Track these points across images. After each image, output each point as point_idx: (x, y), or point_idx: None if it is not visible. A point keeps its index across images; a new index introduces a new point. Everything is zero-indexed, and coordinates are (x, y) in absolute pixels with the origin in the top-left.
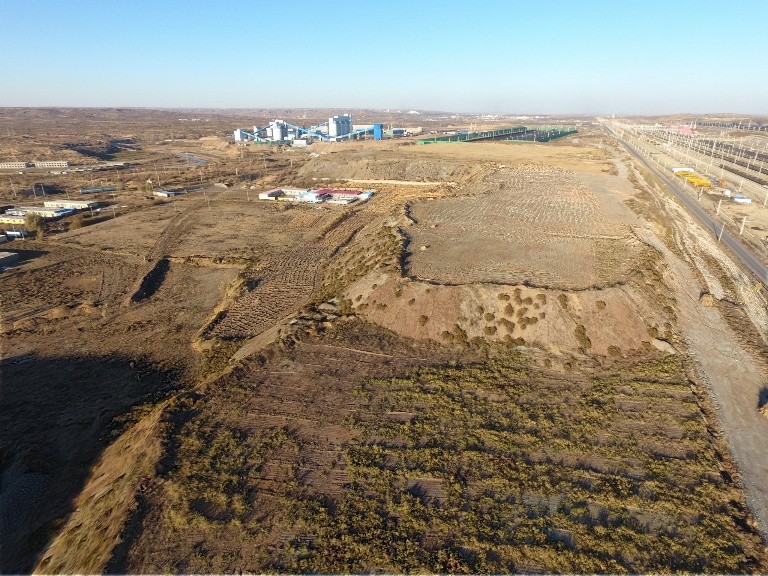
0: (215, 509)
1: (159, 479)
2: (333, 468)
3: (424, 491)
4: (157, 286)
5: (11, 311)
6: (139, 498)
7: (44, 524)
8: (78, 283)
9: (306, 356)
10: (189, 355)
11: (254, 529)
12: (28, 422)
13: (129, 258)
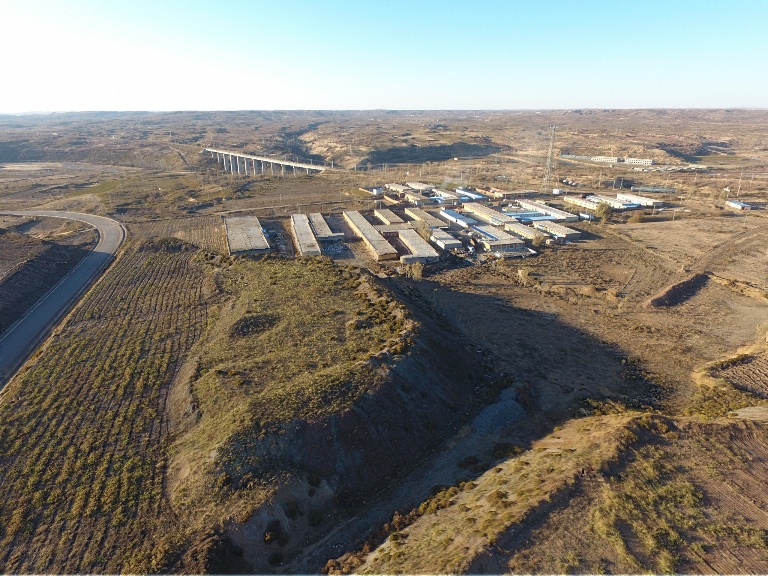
0: (638, 545)
1: (600, 476)
2: None
3: None
4: (683, 299)
5: (554, 276)
6: (577, 478)
7: (507, 443)
8: (611, 271)
9: None
10: (684, 382)
11: None
12: (529, 364)
13: (667, 262)
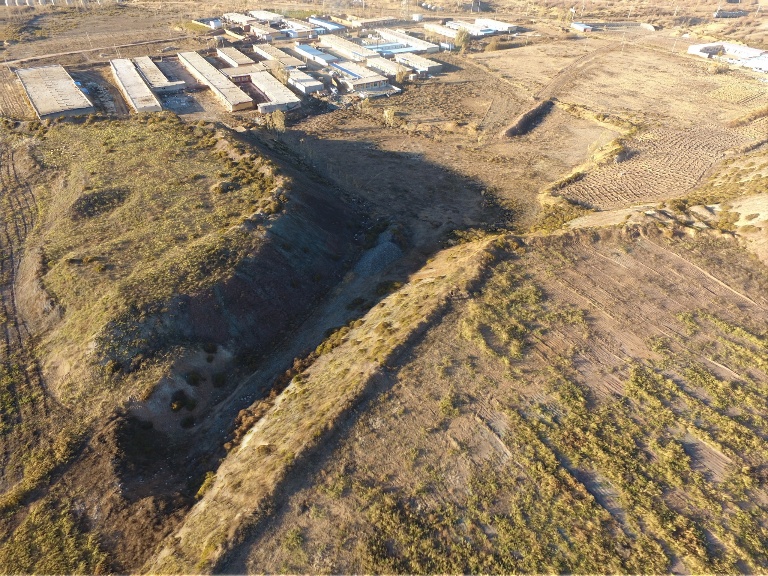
0: (494, 340)
1: (465, 294)
2: (612, 373)
3: (701, 456)
4: (532, 127)
5: (419, 114)
6: (447, 299)
7: (388, 281)
8: None
9: (644, 254)
10: (531, 204)
11: (516, 374)
12: (402, 206)
13: (519, 91)
